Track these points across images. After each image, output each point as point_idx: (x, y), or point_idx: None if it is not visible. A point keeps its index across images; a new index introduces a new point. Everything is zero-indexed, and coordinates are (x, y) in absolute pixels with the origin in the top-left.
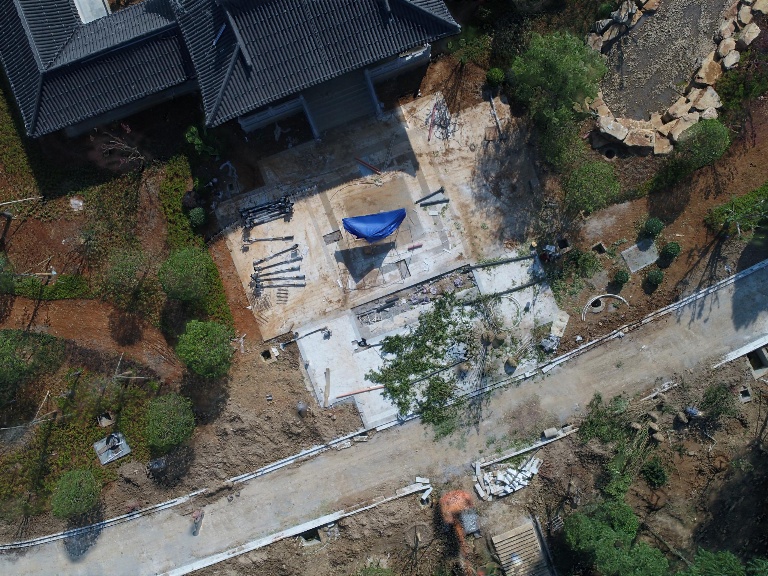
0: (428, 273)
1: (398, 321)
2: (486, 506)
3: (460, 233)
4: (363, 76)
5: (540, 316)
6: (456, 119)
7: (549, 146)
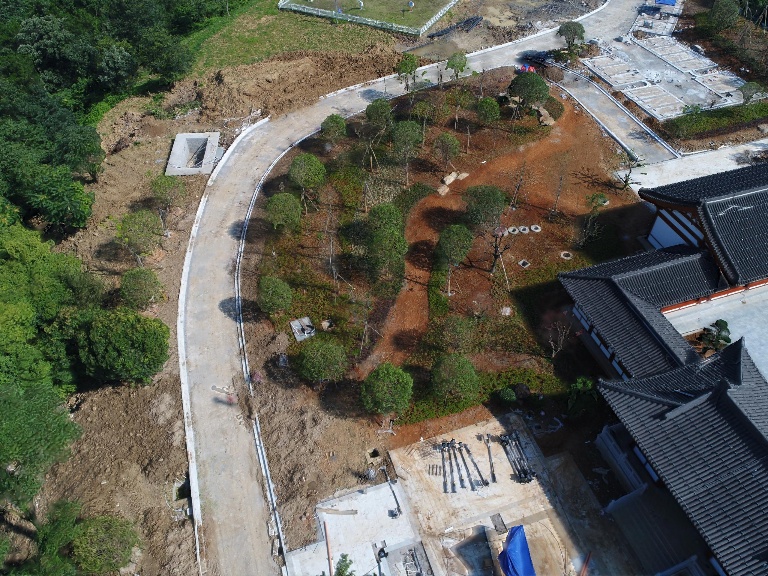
0: None
1: None
2: None
3: None
4: (687, 556)
5: None
6: None
7: None
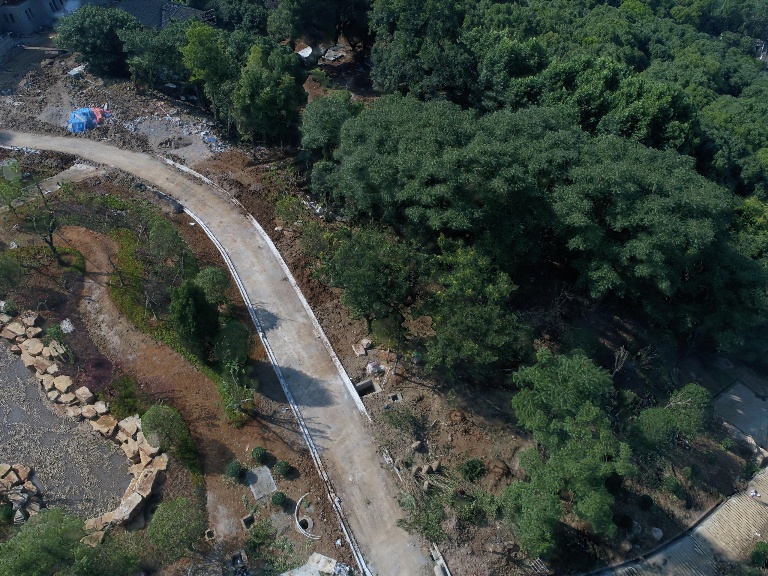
0: None
1: None
2: None
3: None
4: None
5: None
6: None
7: (117, 570)
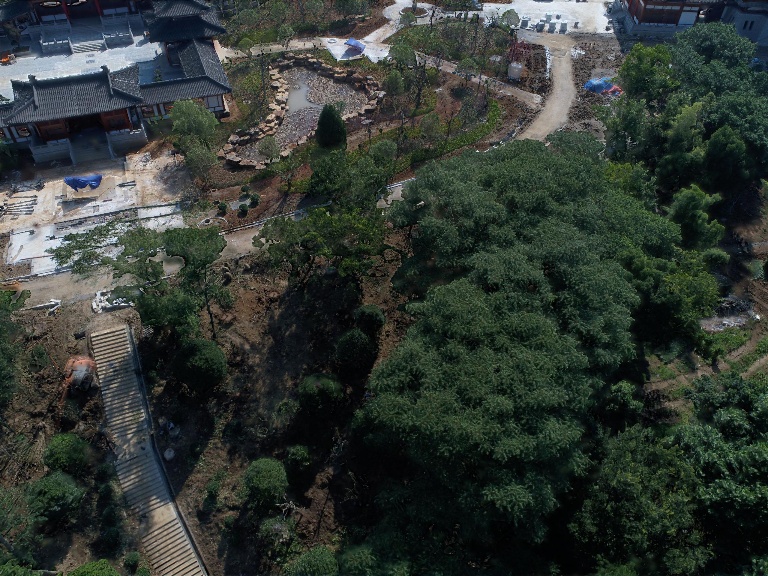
0: (110, 210)
1: (81, 229)
2: (95, 316)
3: (137, 196)
4: (106, 138)
5: (171, 227)
6: (154, 160)
7: None
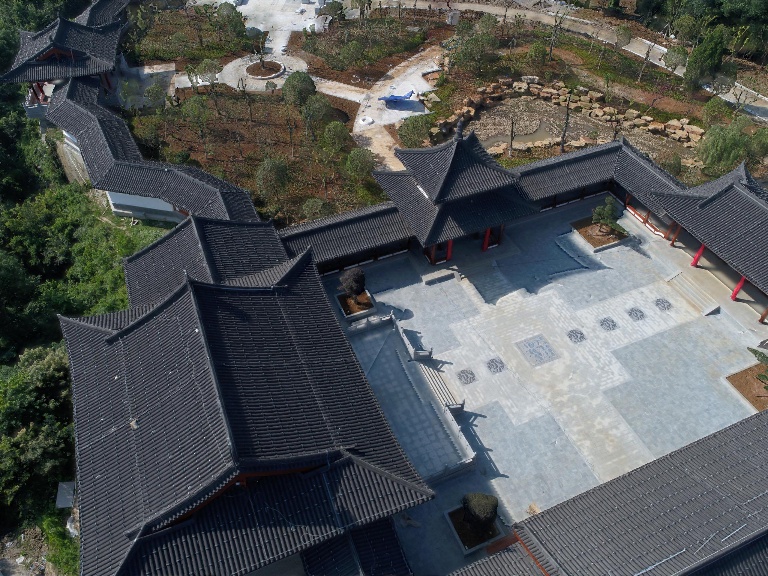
0: None
1: None
2: None
3: None
4: None
5: None
6: None
7: None
